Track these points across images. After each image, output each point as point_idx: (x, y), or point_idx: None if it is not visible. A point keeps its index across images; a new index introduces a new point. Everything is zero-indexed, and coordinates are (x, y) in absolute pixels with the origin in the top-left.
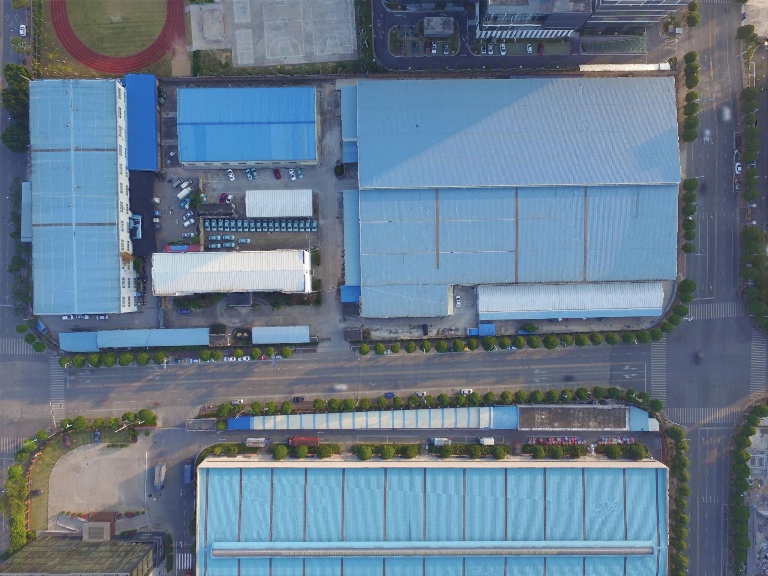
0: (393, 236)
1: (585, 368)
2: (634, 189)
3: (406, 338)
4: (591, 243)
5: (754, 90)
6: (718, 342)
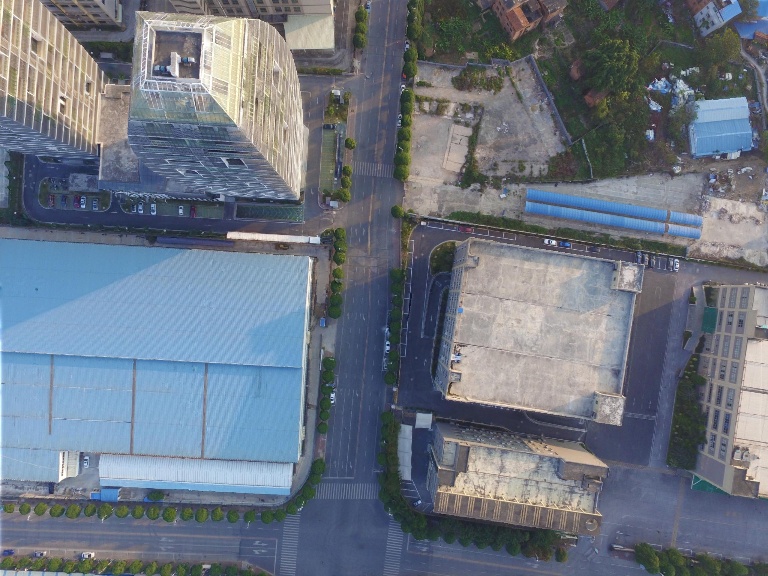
0: (5, 398)
1: (214, 540)
2: (256, 369)
3: (29, 496)
4: (210, 420)
5: (394, 275)
6: (354, 524)
